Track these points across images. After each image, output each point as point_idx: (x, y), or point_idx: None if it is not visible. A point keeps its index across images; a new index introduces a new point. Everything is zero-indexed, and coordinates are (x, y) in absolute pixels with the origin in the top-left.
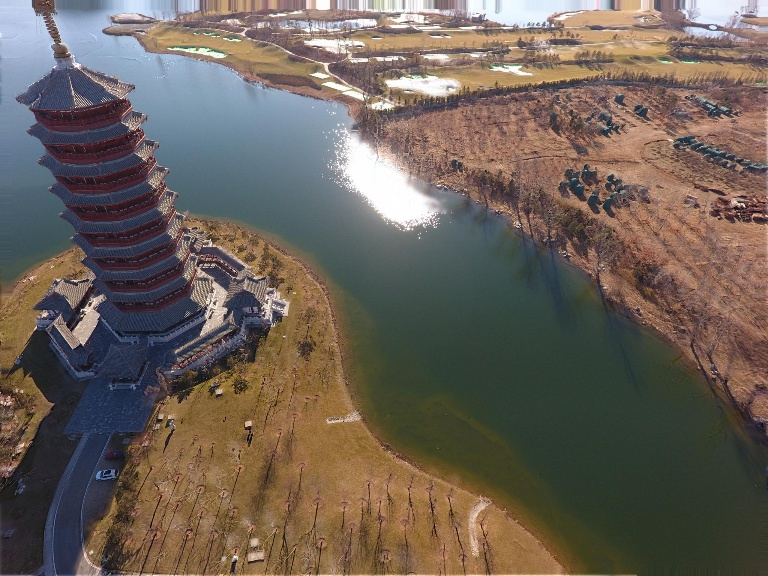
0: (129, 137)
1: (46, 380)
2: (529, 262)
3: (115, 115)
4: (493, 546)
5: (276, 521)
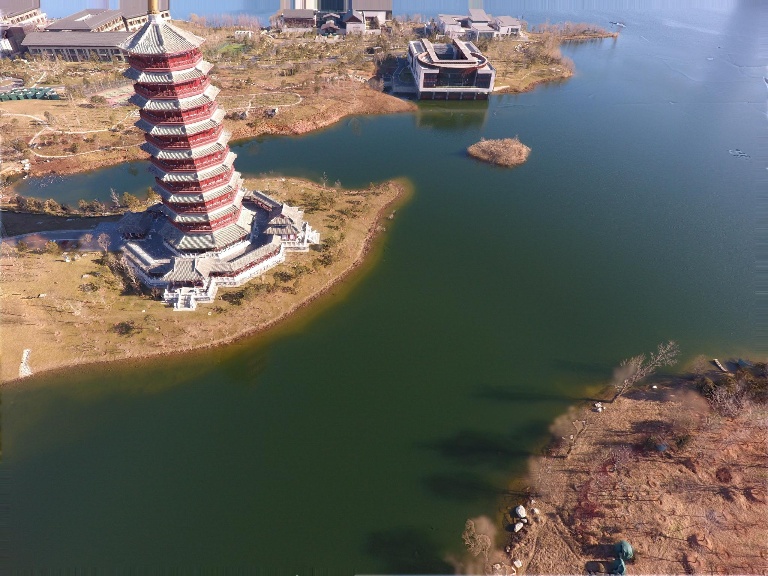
0: (160, 89)
1: None
2: None
3: (140, 65)
4: None
5: None
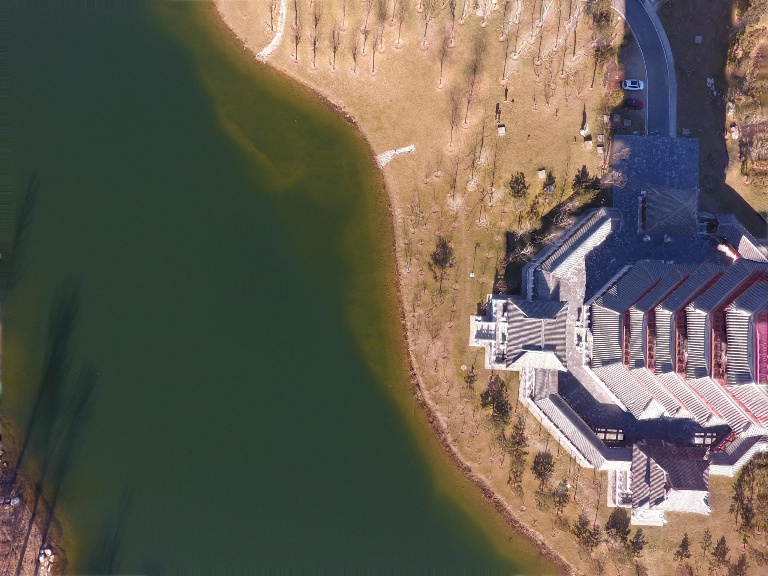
0: None
1: (752, 221)
2: (70, 440)
3: None
4: (267, 8)
5: (462, 29)
